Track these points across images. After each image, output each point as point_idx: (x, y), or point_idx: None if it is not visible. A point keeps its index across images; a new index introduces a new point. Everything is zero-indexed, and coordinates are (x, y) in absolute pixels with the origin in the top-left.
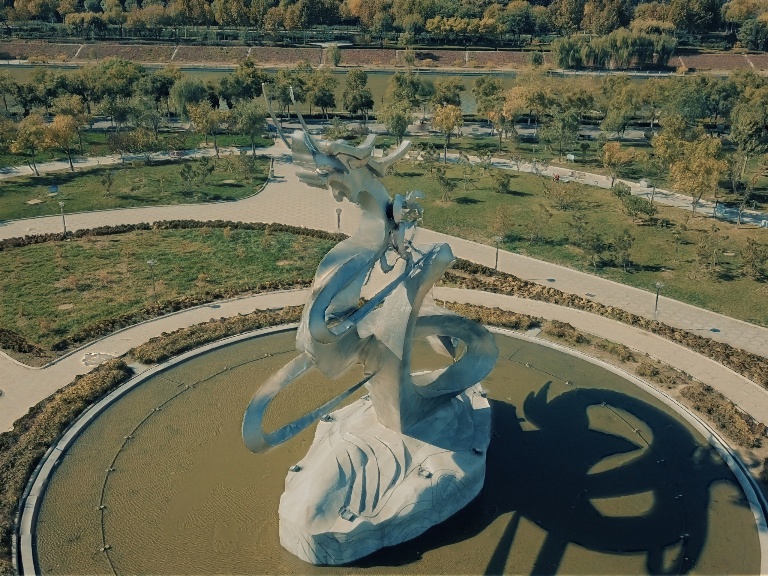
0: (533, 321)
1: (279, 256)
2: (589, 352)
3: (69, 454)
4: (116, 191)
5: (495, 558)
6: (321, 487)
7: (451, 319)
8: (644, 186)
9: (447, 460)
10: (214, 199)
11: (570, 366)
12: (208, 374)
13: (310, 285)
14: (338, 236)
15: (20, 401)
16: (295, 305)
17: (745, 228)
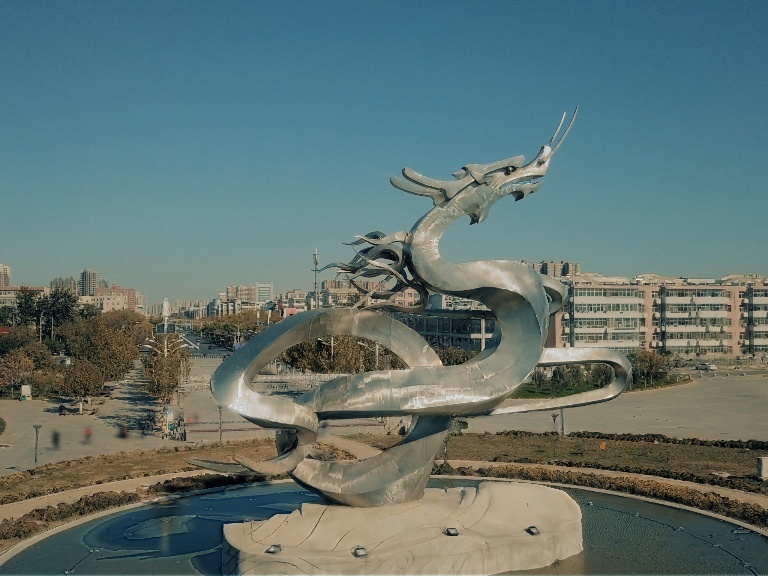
0: None
1: None
2: None
3: None
4: None
5: None
6: None
7: None
8: None
9: None
10: None
11: (40, 560)
12: None
13: None
14: None
15: None
16: None
17: None
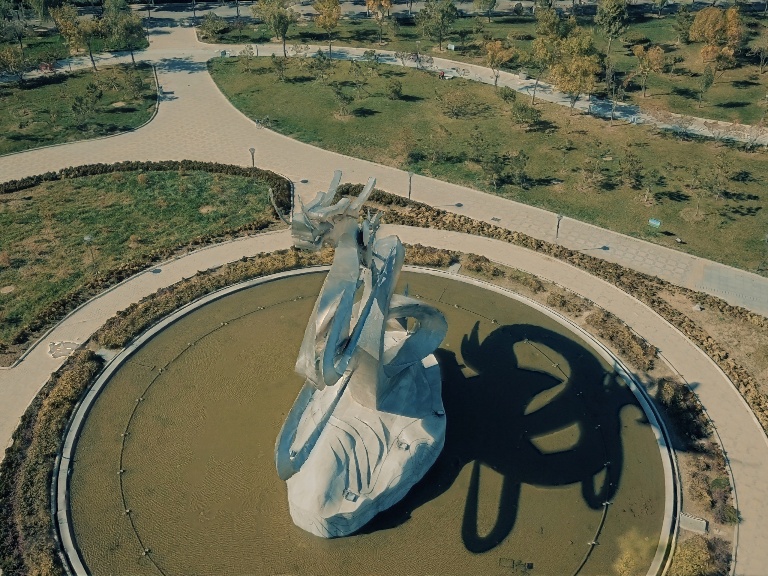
0: (453, 257)
1: (201, 202)
2: (505, 285)
3: (76, 460)
4: (4, 130)
5: (468, 507)
6: (325, 477)
7: (408, 307)
8: (523, 78)
9: (419, 430)
10: (111, 130)
11: (492, 303)
12: (175, 353)
13: (240, 234)
14: (252, 171)
15: (6, 409)
16: (233, 261)
17: (617, 125)
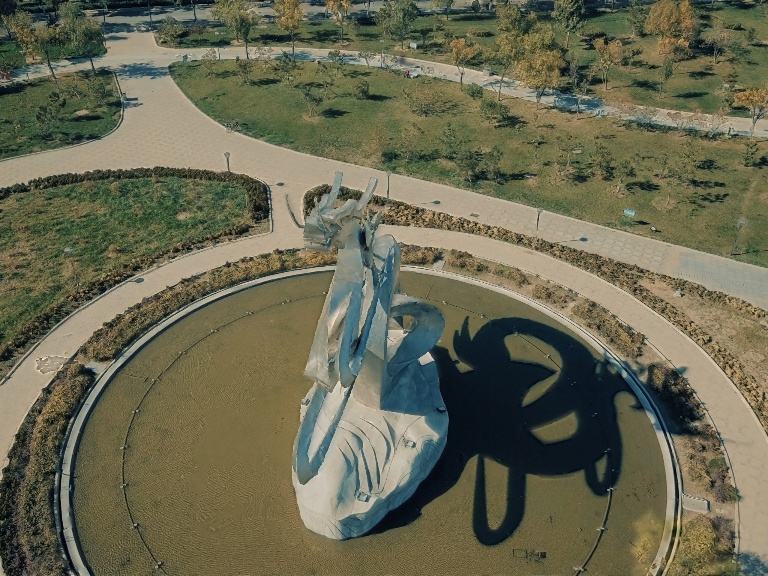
0: (436, 254)
1: (177, 209)
2: (490, 280)
3: (77, 476)
4: None
5: (477, 501)
6: (336, 479)
7: (407, 305)
8: (487, 75)
9: (423, 427)
10: (77, 139)
11: (479, 298)
12: (167, 362)
13: (220, 240)
14: (226, 176)
15: None
16: (216, 267)
17: (583, 118)
